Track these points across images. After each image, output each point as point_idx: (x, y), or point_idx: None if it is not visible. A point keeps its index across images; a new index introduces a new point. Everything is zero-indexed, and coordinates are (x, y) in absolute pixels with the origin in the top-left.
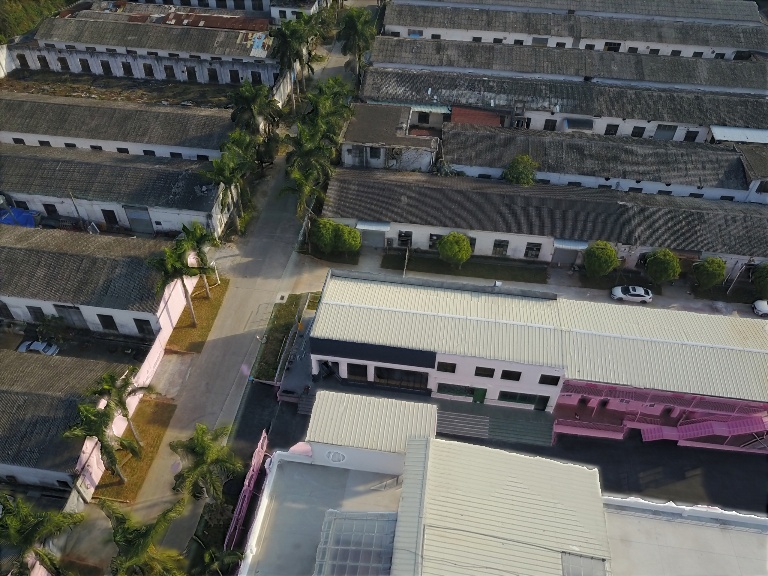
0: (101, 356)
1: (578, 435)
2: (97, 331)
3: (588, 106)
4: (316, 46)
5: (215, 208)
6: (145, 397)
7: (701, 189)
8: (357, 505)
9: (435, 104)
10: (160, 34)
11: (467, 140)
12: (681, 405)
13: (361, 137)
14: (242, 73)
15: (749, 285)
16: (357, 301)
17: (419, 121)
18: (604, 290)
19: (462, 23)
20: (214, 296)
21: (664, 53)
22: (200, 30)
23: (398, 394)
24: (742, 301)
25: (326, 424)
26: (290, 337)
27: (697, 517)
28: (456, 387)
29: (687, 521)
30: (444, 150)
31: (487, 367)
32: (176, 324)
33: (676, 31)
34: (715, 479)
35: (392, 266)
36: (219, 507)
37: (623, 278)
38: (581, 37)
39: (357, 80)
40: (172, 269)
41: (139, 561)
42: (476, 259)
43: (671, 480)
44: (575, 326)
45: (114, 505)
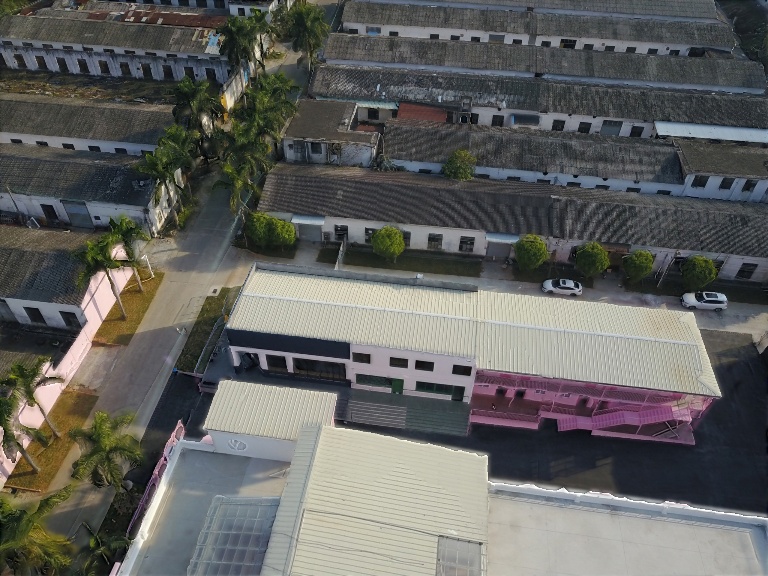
0: (29, 349)
1: (494, 425)
2: (26, 324)
3: (534, 102)
4: (274, 43)
5: (152, 203)
6: (68, 389)
7: (638, 183)
8: (254, 492)
9: (383, 100)
10: (117, 31)
11: (408, 135)
12: (593, 395)
13: (302, 132)
14: (196, 70)
15: (680, 278)
16: (278, 293)
17: (369, 117)
18: (536, 283)
19: (419, 20)
20: (147, 289)
21: (619, 50)
22: (156, 27)
23: (319, 385)
24: (672, 294)
25: (225, 412)
26: (214, 329)
27: (589, 503)
28: (377, 378)
29: (579, 507)
30: (385, 145)
31: (400, 358)
32: (106, 317)
33: (631, 28)
34: (625, 468)
35: (328, 260)
36: (130, 496)
37: (556, 271)
38: (537, 34)
39: (310, 77)
40: (93, 262)
41: (16, 545)
42: (412, 253)
43: (581, 469)
44: (491, 317)
45: (25, 494)
